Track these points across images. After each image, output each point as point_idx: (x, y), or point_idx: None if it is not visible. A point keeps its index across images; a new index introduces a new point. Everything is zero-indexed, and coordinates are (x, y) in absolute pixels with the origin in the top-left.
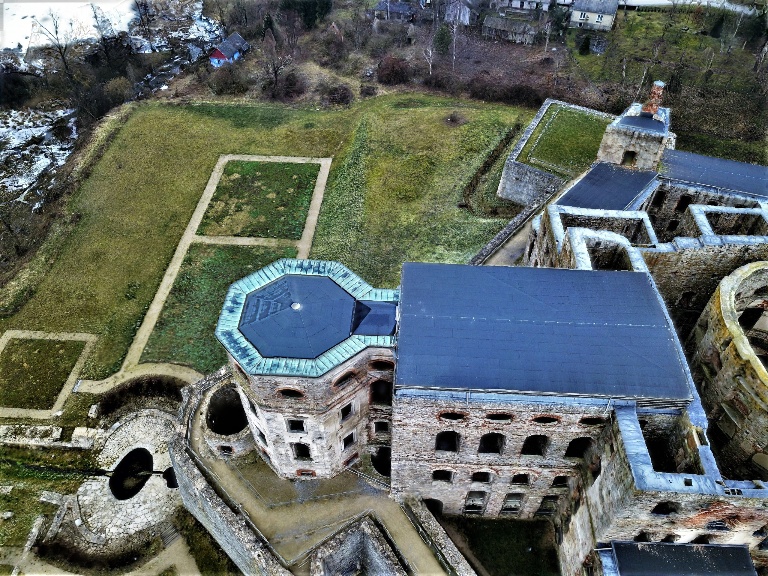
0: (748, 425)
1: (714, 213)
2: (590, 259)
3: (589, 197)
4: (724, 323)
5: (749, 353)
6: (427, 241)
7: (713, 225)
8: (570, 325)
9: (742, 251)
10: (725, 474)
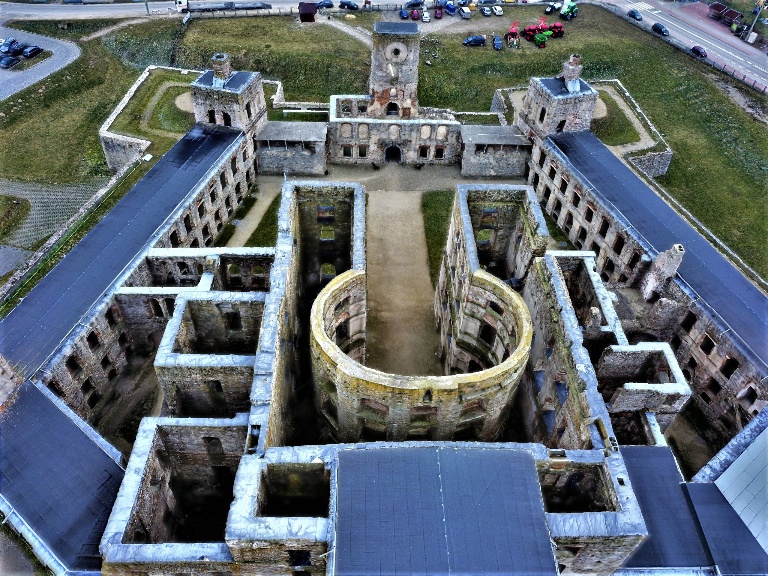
0: (491, 407)
1: None
2: (260, 515)
3: (49, 486)
4: (411, 390)
5: (452, 381)
6: None
7: (178, 350)
8: (453, 570)
9: (279, 338)
10: (489, 441)
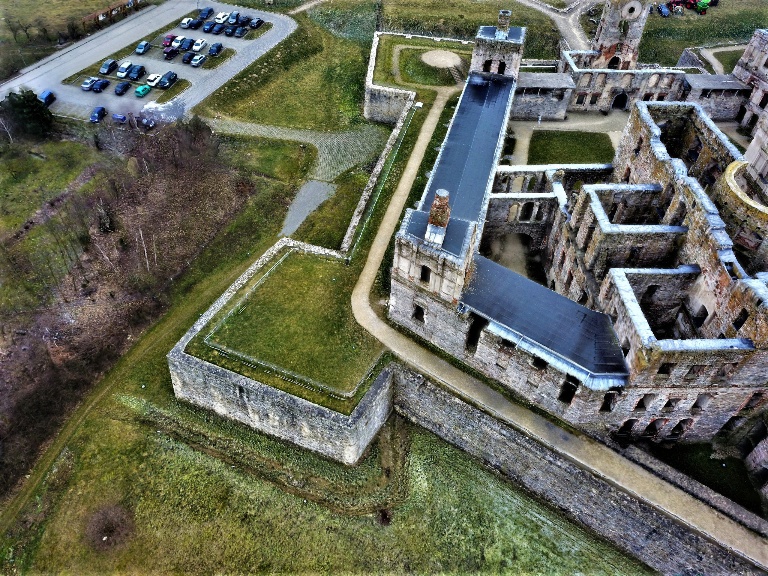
0: None
1: (591, 221)
2: None
3: (542, 322)
4: None
5: None
6: (478, 575)
7: None
8: None
9: None
10: None
